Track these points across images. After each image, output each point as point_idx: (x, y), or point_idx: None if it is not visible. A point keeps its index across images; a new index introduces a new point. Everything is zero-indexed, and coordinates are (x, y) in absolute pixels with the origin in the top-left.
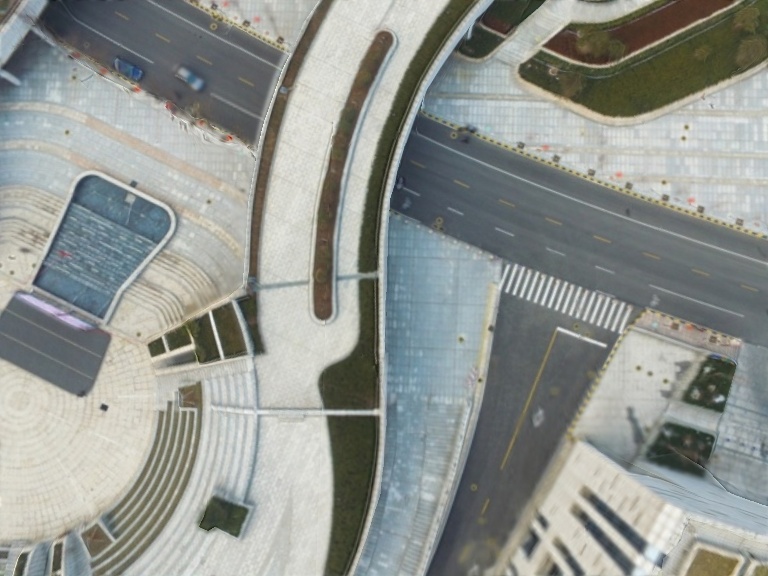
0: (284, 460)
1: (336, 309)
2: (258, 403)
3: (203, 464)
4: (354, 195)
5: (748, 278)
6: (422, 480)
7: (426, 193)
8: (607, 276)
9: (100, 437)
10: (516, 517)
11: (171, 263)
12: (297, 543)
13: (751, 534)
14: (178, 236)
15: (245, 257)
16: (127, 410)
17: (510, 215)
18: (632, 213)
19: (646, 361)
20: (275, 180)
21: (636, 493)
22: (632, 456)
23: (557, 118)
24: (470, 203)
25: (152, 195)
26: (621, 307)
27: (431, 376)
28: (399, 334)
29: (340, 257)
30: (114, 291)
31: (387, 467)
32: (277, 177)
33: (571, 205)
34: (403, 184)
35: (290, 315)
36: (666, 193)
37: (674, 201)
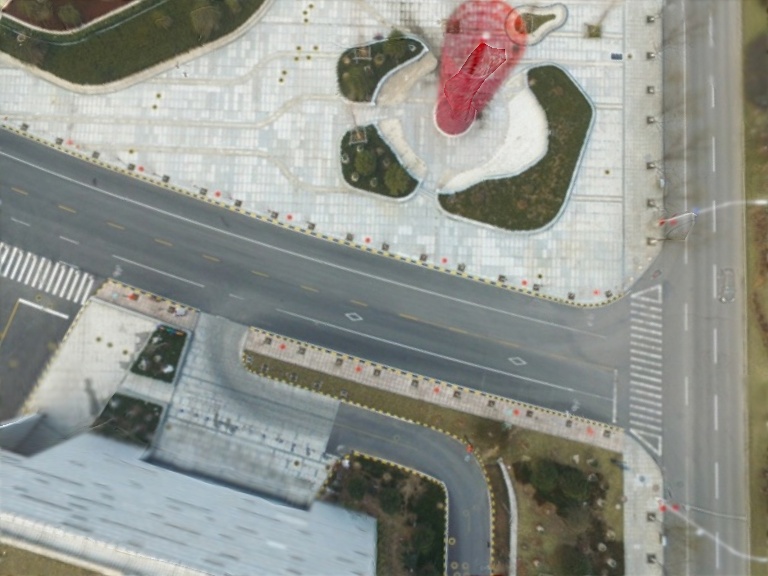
0: None
1: None
2: None
3: None
4: None
5: (210, 248)
6: None
7: None
8: (71, 247)
9: None
10: None
11: None
12: None
13: None
14: None
15: None
16: None
17: None
18: (99, 183)
19: (106, 332)
20: None
21: None
22: (78, 428)
23: (27, 86)
24: None
25: None
26: (84, 278)
27: None
28: None
29: None
30: None
31: None
32: None
33: (38, 175)
34: None
35: None
36: (132, 162)
37: (139, 170)
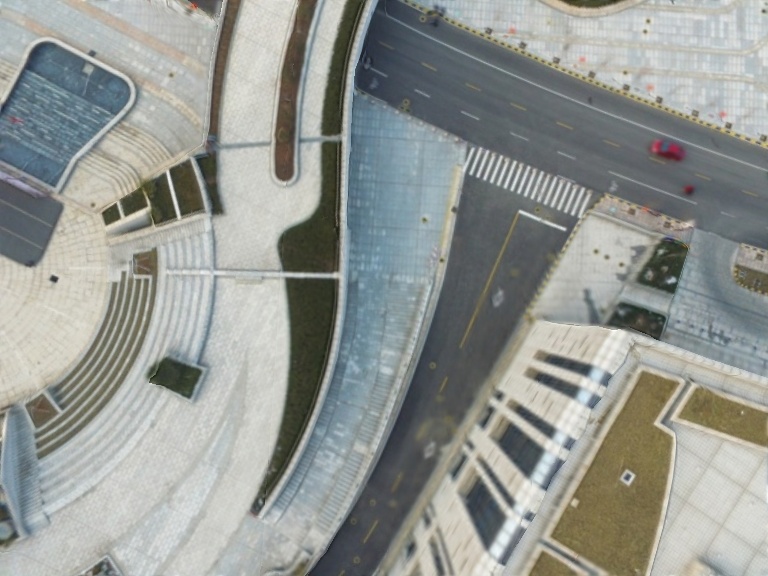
0: (240, 322)
1: (298, 171)
2: (215, 263)
3: (156, 330)
4: (319, 57)
5: (702, 167)
6: (381, 354)
7: (393, 74)
8: (568, 162)
9: (49, 309)
10: (473, 395)
11: (129, 135)
12: (251, 406)
13: (692, 355)
14: (138, 108)
15: (206, 116)
16: (78, 282)
17: (476, 99)
18: (594, 101)
19: (603, 245)
20: (239, 39)
21: (586, 333)
22: None
23: (524, 6)
24: (437, 86)
25: (111, 65)
26: (581, 192)
27: (393, 255)
28: (362, 213)
29: (303, 119)
30: (68, 159)
31: (346, 340)
32: (241, 36)
33: (536, 91)
34: (371, 65)
35: (250, 176)
36: (627, 83)
37: (634, 91)
